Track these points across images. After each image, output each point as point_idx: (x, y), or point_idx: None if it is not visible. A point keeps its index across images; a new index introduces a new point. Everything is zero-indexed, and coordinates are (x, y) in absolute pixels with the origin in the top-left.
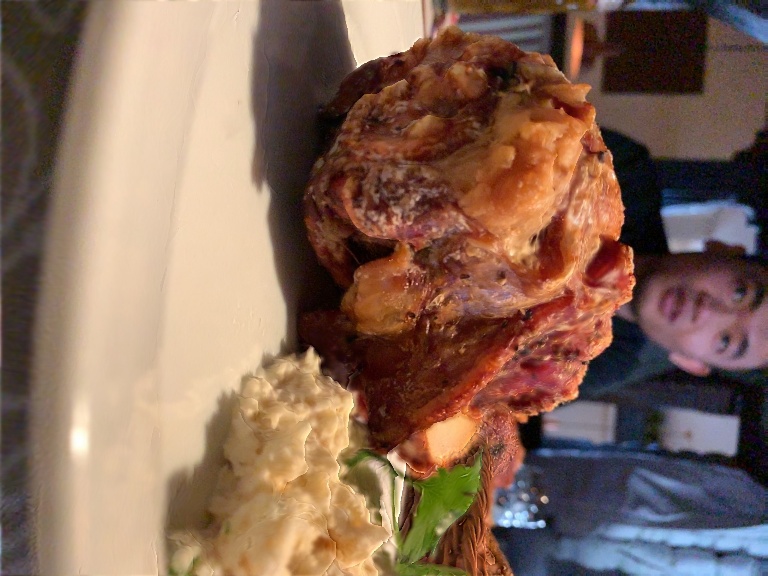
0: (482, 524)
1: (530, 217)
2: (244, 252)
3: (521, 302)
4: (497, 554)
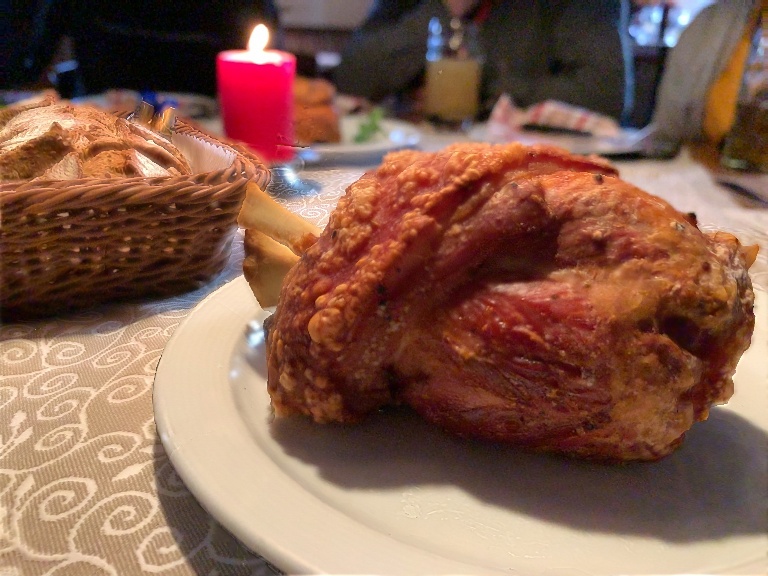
0: (183, 186)
1: None
2: None
3: None
4: (42, 149)
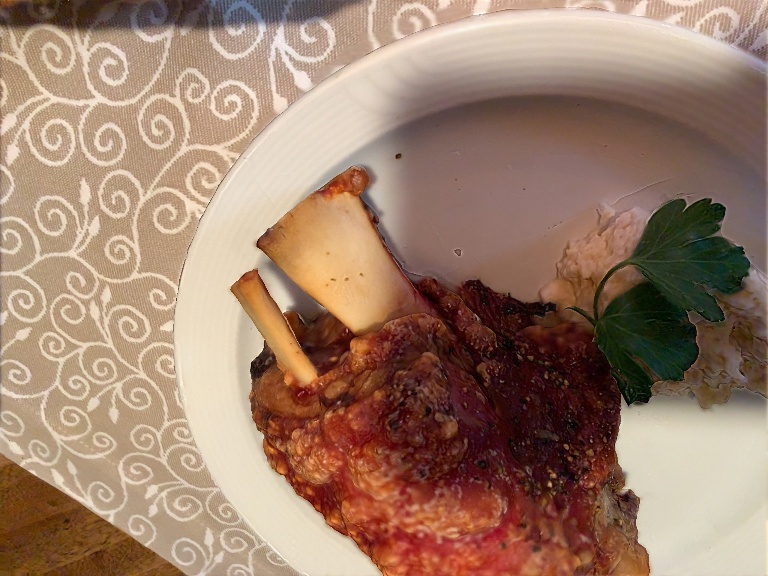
0: None
1: (640, 572)
2: (640, 445)
3: (604, 516)
4: None
